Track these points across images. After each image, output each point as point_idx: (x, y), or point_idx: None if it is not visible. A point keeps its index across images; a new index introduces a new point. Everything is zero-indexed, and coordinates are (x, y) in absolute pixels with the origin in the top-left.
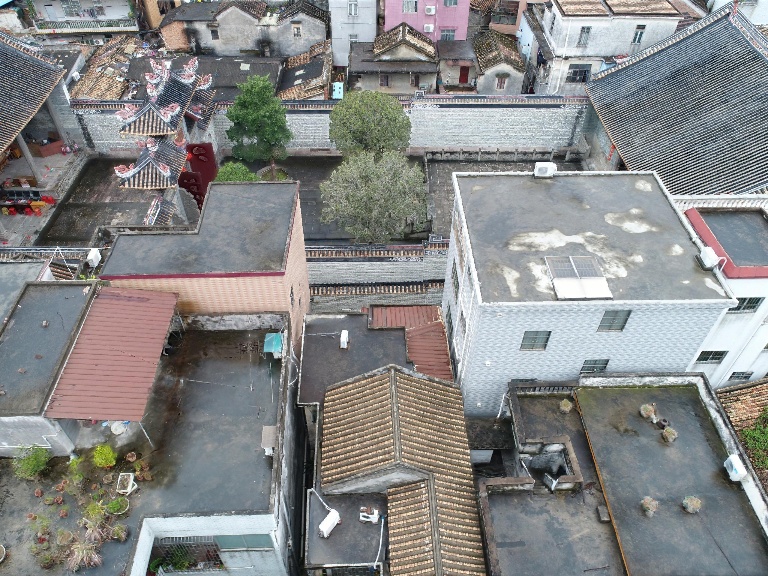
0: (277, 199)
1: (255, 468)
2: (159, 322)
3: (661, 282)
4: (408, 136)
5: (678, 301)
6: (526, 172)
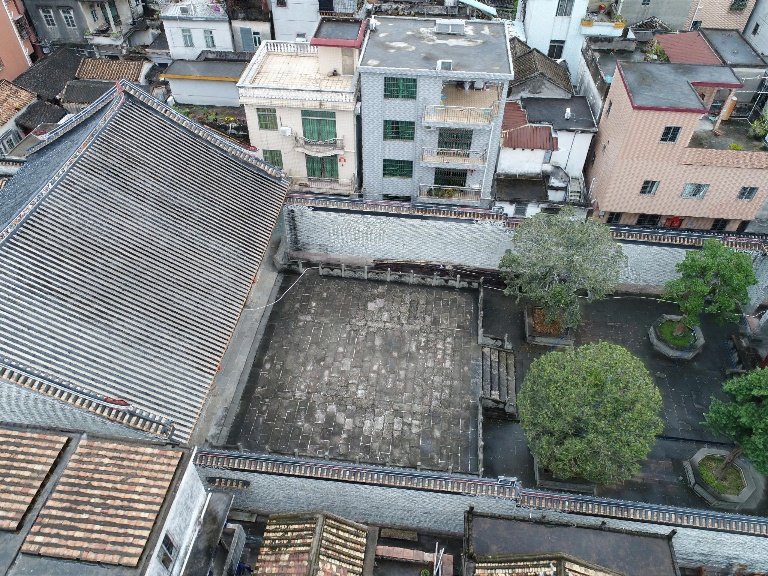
0: (645, 96)
1: (598, 61)
2: (677, 61)
3: (404, 25)
4: (524, 384)
5: (403, 17)
6: (457, 71)
